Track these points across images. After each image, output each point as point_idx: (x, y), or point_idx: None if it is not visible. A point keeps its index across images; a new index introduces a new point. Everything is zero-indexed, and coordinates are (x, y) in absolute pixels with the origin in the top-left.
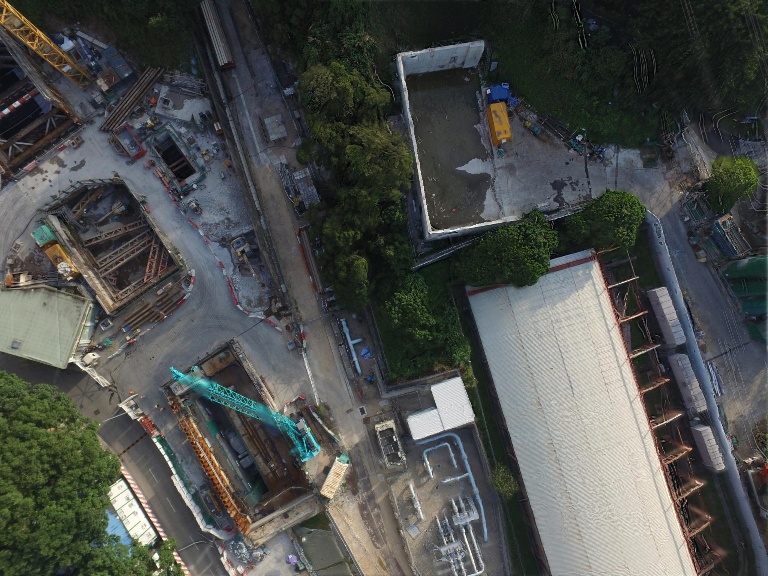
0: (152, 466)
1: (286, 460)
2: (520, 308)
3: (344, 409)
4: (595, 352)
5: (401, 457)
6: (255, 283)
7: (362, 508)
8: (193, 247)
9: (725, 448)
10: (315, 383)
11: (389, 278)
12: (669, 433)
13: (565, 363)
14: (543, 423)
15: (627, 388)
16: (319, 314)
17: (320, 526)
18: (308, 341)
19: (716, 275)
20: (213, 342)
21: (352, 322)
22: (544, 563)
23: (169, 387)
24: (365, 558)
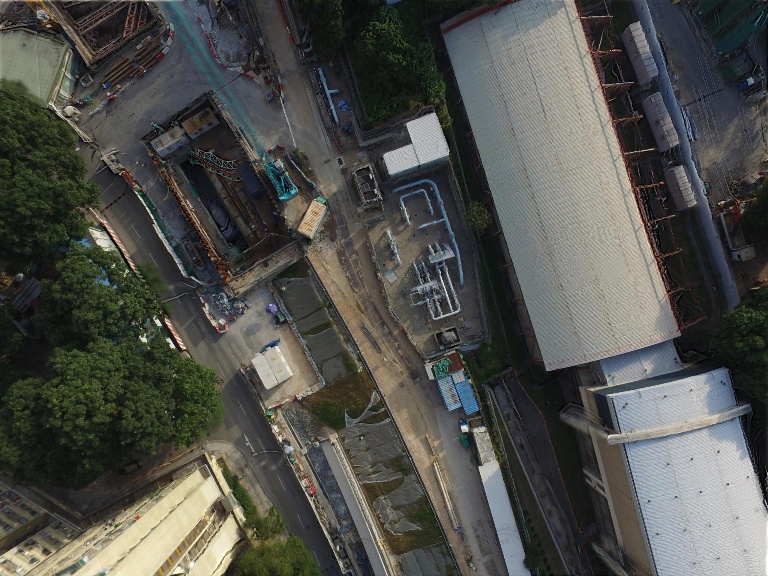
0: (134, 222)
1: (266, 221)
2: (493, 37)
3: (322, 159)
4: (567, 77)
5: (377, 194)
6: (233, 34)
7: (340, 254)
8: (171, 3)
9: (698, 189)
10: (293, 133)
11: (365, 20)
12: None
13: (538, 87)
14: (516, 151)
15: (599, 113)
16: (297, 66)
17: (299, 274)
18: (286, 93)
19: (690, 18)
20: (192, 97)
21: (329, 75)
22: (518, 298)
23: (150, 144)
24: (343, 302)
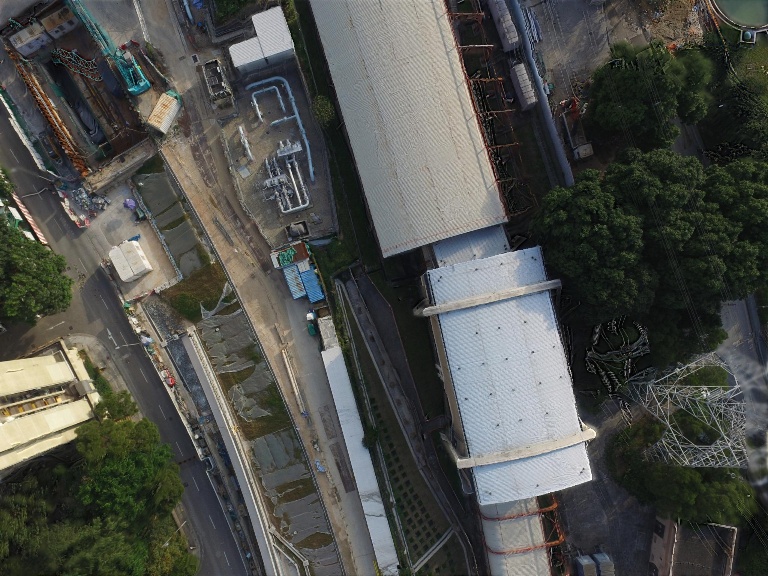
0: None
1: (129, 121)
2: None
3: (177, 56)
4: None
5: (225, 87)
6: None
7: (194, 149)
8: None
9: (539, 88)
10: (148, 30)
11: None
12: (493, 87)
13: None
14: (355, 43)
15: (434, 5)
16: None
17: (155, 170)
18: None
19: None
20: None
21: None
22: None
23: (9, 40)
24: (197, 196)
